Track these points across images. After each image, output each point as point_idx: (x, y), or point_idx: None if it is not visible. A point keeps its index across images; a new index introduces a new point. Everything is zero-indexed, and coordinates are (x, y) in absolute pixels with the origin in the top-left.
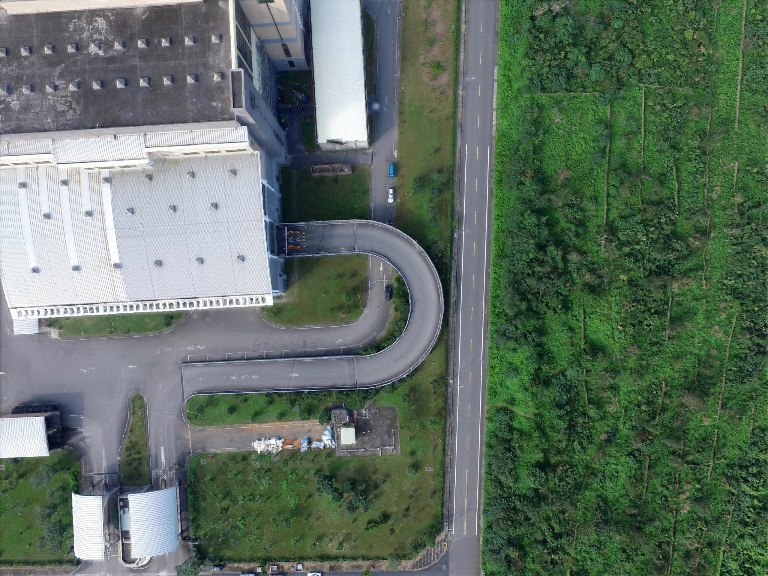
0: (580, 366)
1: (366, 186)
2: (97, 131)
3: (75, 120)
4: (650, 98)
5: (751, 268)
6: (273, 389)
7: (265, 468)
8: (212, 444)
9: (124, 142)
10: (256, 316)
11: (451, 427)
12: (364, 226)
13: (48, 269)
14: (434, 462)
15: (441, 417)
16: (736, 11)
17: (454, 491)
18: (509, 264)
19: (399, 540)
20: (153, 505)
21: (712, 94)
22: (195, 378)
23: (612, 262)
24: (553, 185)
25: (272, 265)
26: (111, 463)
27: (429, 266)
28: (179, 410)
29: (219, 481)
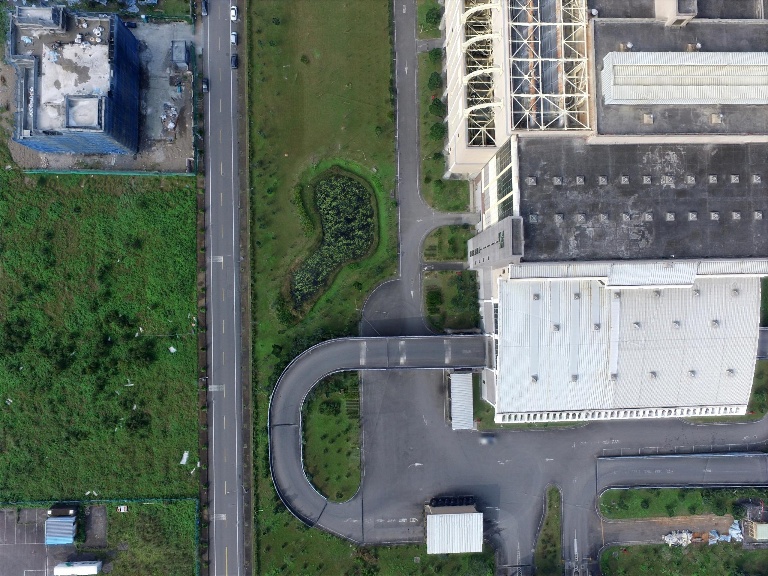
0: None
1: None
2: None
3: (648, 249)
4: None
5: None
6: (687, 484)
7: (676, 561)
8: (624, 537)
9: (678, 269)
10: None
11: None
12: None
13: (546, 377)
14: None
15: None
16: None
17: None
18: None
19: None
20: None
21: None
22: (609, 472)
23: None
24: None
25: None
26: (525, 555)
27: None
28: (592, 503)
29: (631, 573)
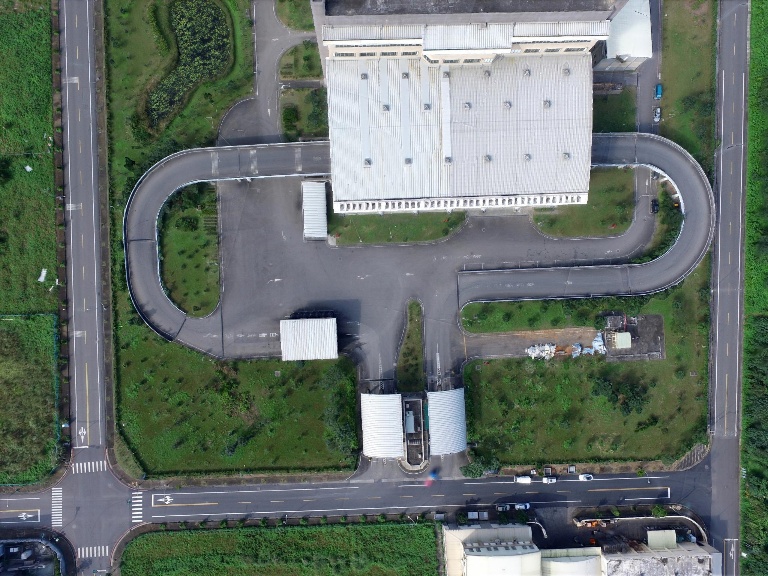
0: None
1: (633, 106)
2: (478, 16)
3: (457, 5)
4: None
5: None
6: (548, 296)
7: (539, 373)
8: (486, 351)
9: (493, 30)
10: (529, 227)
11: (712, 334)
12: (644, 139)
13: (380, 161)
14: (697, 367)
15: None
16: None
17: (715, 395)
18: None
19: (665, 442)
20: (449, 403)
21: None
22: (471, 286)
23: None
24: None
25: None
26: (387, 369)
27: (701, 179)
28: (454, 317)
29: (494, 386)
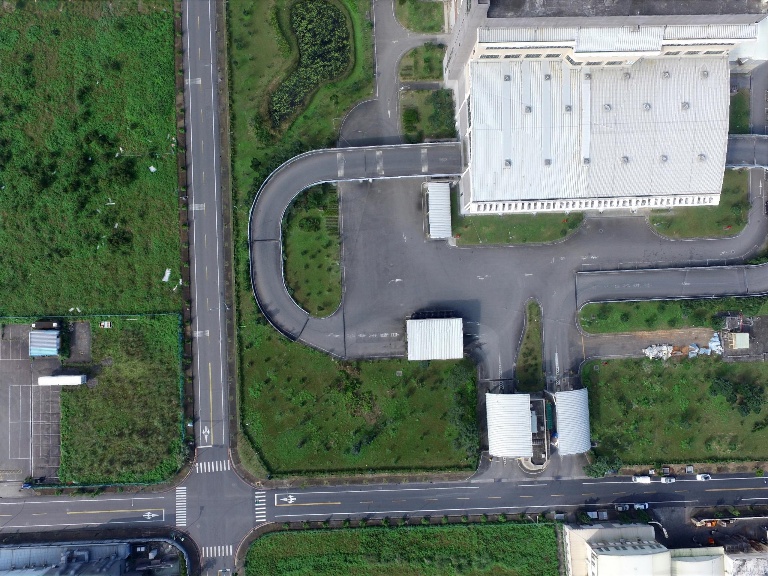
0: None
1: (746, 108)
2: (633, 19)
3: (613, 7)
4: None
5: None
6: (666, 297)
7: (656, 373)
8: (604, 351)
9: (645, 33)
10: (646, 228)
11: None
12: (763, 141)
13: (519, 162)
14: None
15: None
16: None
17: None
18: None
19: None
20: (576, 403)
21: None
22: (588, 287)
23: None
24: None
25: None
26: (507, 369)
27: None
28: (573, 318)
29: (612, 386)
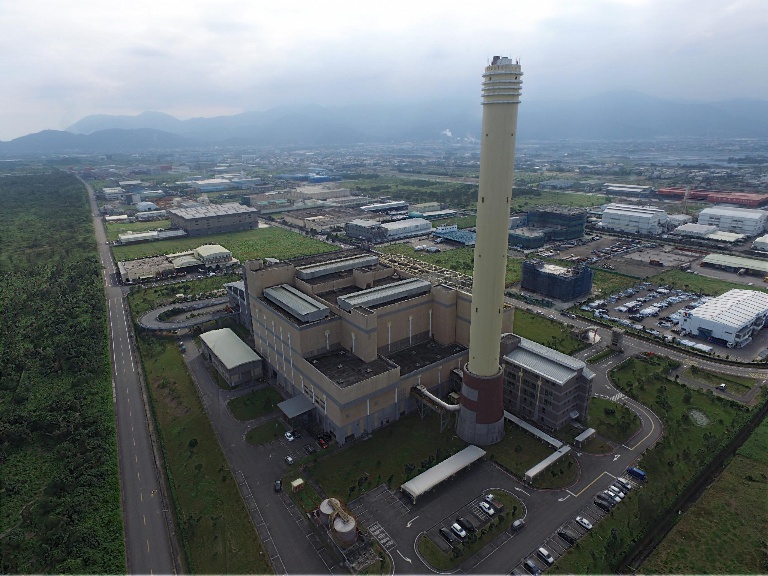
0: None
1: (199, 343)
2: None
3: None
4: None
5: None
6: None
7: None
8: None
9: None
10: None
11: None
12: None
13: None
14: None
15: None
16: None
17: None
18: None
19: None
20: None
21: None
22: None
23: None
24: None
25: None
26: None
27: None
28: None
29: None
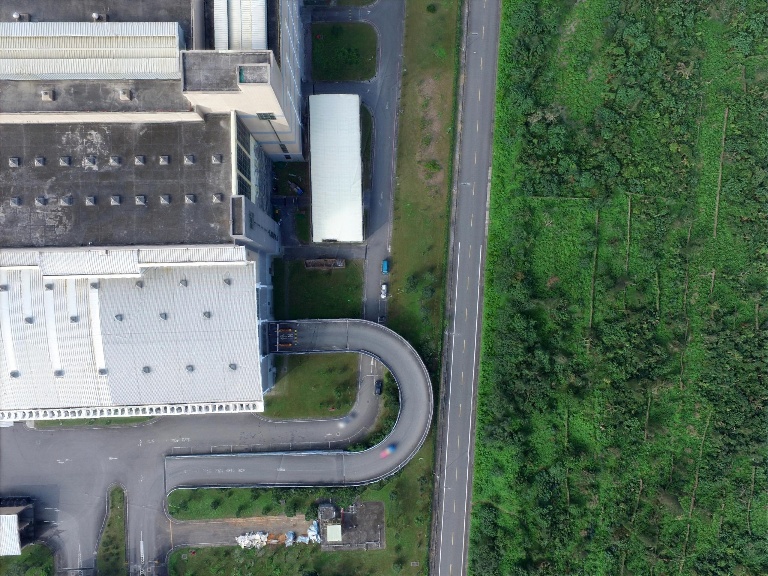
0: (563, 466)
1: (359, 280)
2: (88, 248)
3: (65, 236)
4: (636, 207)
5: (725, 373)
6: (259, 484)
7: (248, 563)
8: (194, 539)
9: (116, 257)
10: None
11: (436, 522)
12: (357, 325)
13: (28, 373)
14: (419, 557)
15: (427, 513)
16: (717, 125)
17: None
18: (498, 364)
19: None
20: None
21: (693, 203)
22: (178, 471)
23: (596, 364)
24: (542, 286)
25: (263, 366)
26: (87, 558)
27: (420, 366)
28: (161, 504)
29: None
